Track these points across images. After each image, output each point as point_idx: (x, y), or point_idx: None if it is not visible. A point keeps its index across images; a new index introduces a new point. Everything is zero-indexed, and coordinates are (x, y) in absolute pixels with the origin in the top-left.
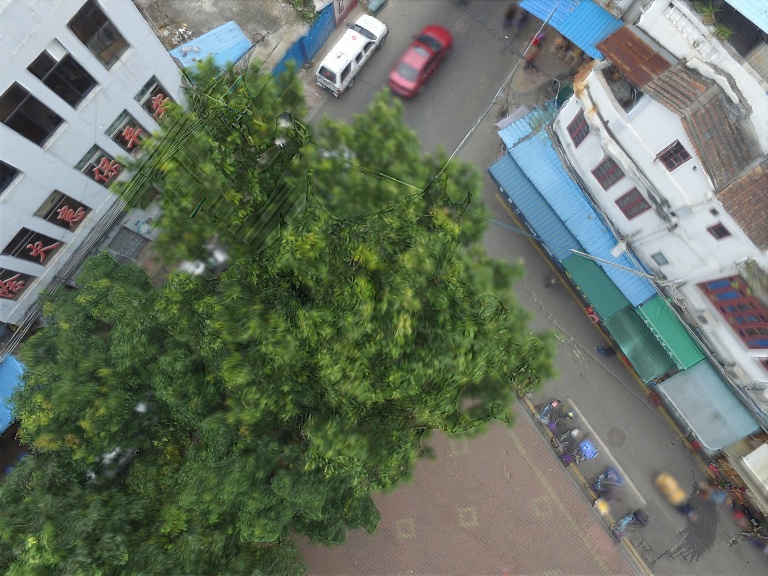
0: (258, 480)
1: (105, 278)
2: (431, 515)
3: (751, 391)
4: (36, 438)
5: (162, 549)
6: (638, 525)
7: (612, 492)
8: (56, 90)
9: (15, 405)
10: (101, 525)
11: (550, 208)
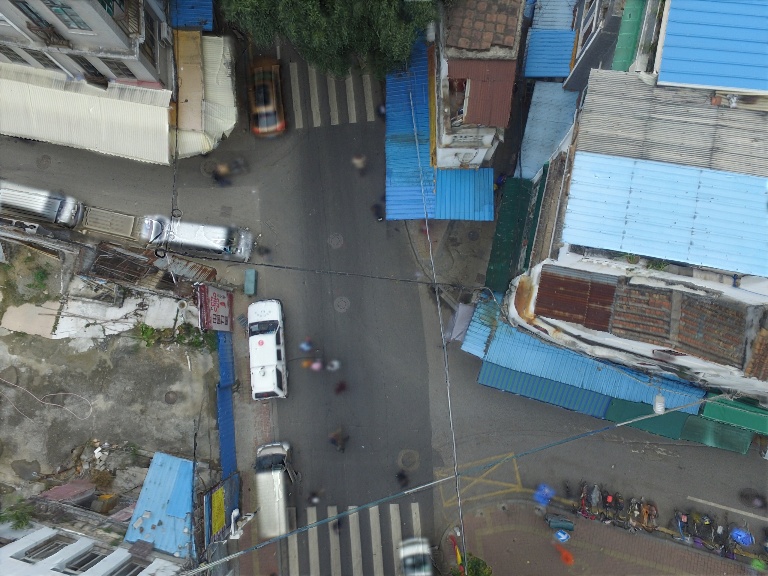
0: None
1: None
2: None
3: None
4: None
5: None
6: None
7: None
8: None
9: None
10: None
11: None
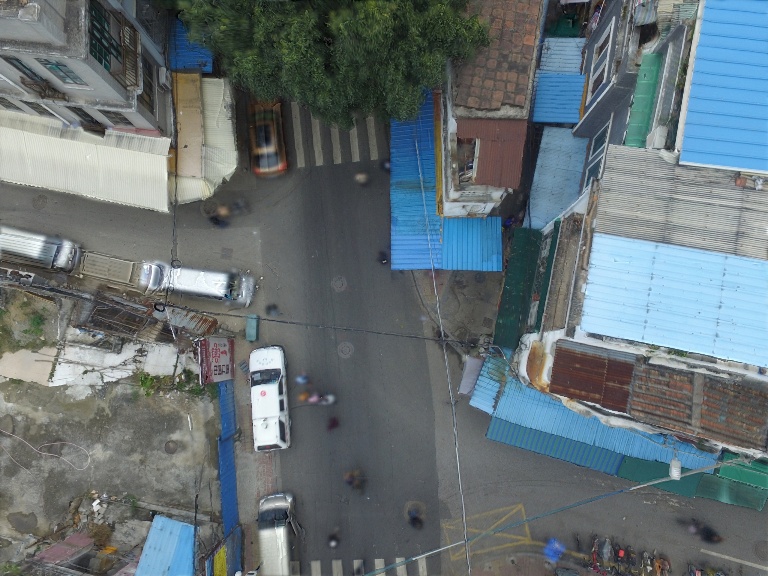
0: None
1: None
2: None
3: None
4: None
5: None
6: None
7: None
8: None
9: None
10: None
11: None
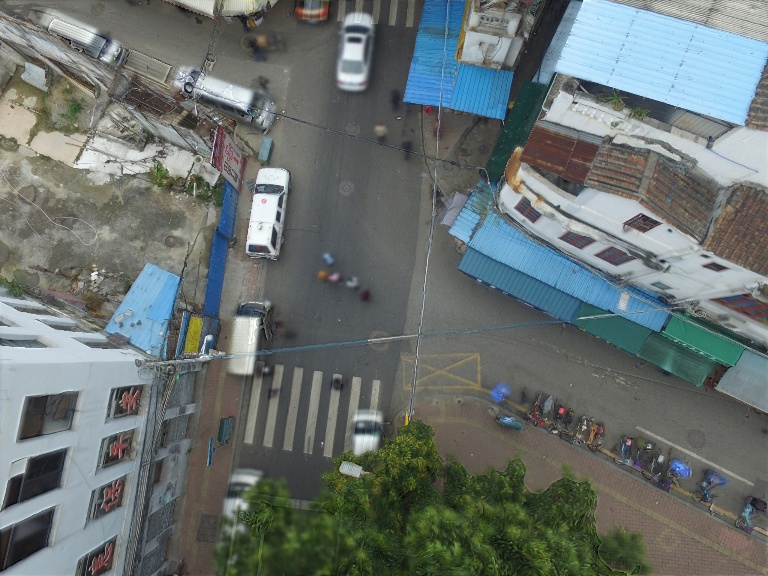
0: None
1: None
2: None
3: None
4: None
5: None
6: None
7: (720, 492)
8: (35, 493)
9: None
10: None
11: (534, 279)
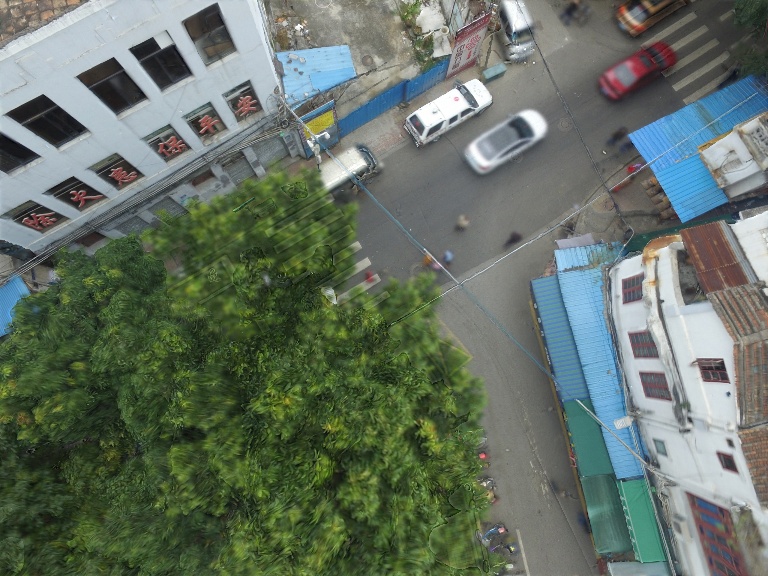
0: None
1: (121, 266)
2: None
3: None
4: None
5: (61, 560)
6: None
7: None
8: (150, 72)
9: None
10: (14, 519)
11: (574, 346)
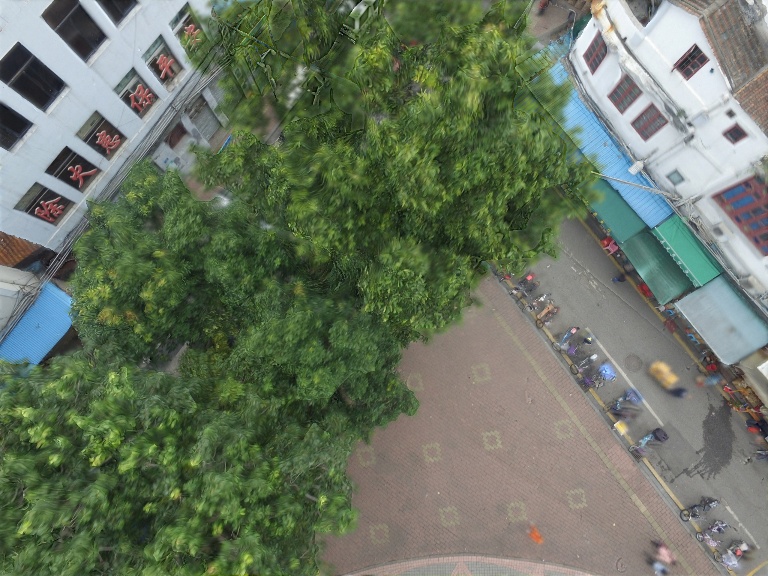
0: (317, 332)
1: None
2: (456, 439)
3: (766, 300)
4: (101, 309)
5: (222, 413)
6: (656, 446)
7: (630, 415)
8: (101, 4)
9: (76, 288)
10: (167, 385)
11: (567, 138)
